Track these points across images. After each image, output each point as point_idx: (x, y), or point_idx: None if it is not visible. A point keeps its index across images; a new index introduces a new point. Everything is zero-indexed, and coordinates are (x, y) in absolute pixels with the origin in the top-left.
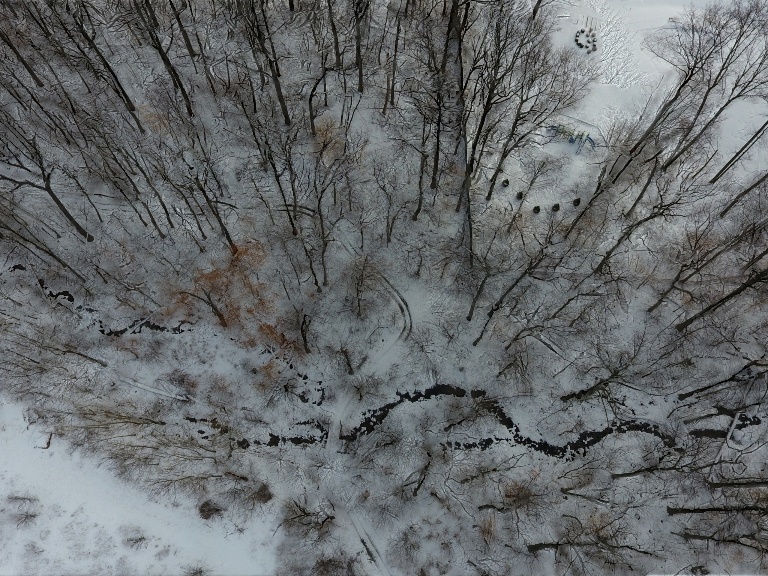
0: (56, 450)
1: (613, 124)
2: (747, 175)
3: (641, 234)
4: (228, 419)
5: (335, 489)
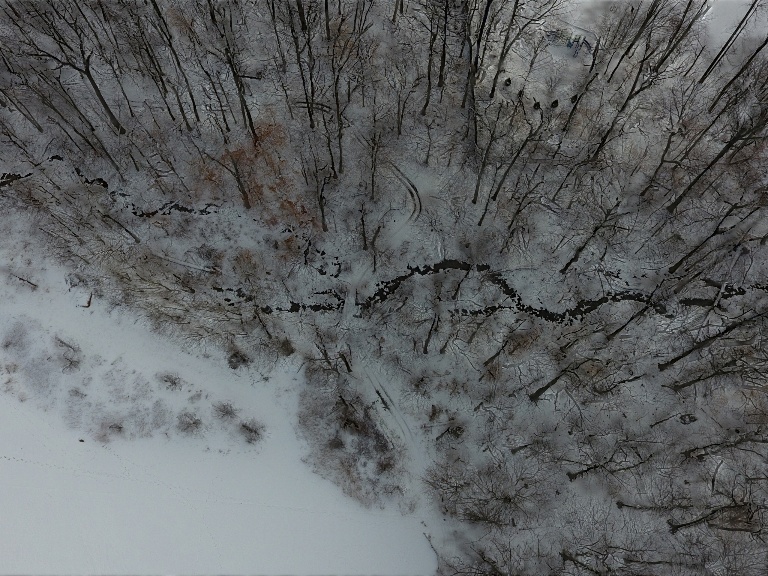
0: (96, 309)
1: (608, 29)
2: (732, 69)
3: (634, 123)
4: (252, 288)
5: (352, 348)
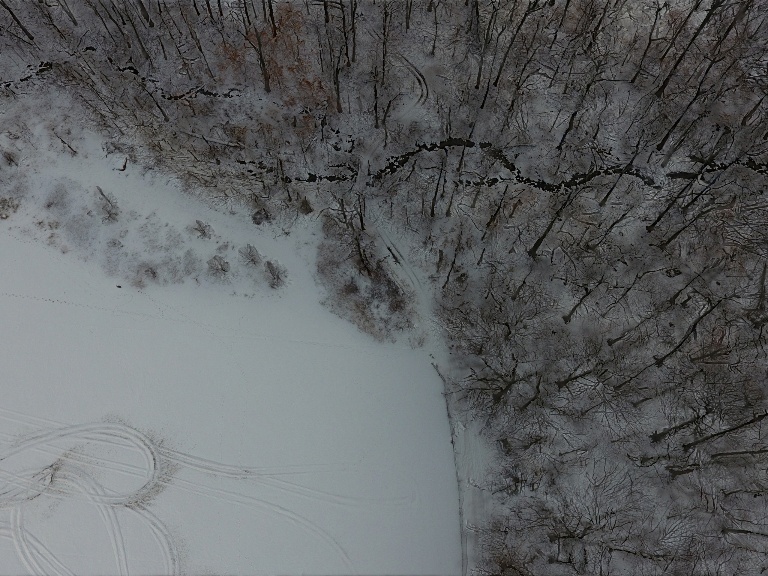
0: (131, 172)
1: None
2: None
3: None
4: (273, 161)
5: None
